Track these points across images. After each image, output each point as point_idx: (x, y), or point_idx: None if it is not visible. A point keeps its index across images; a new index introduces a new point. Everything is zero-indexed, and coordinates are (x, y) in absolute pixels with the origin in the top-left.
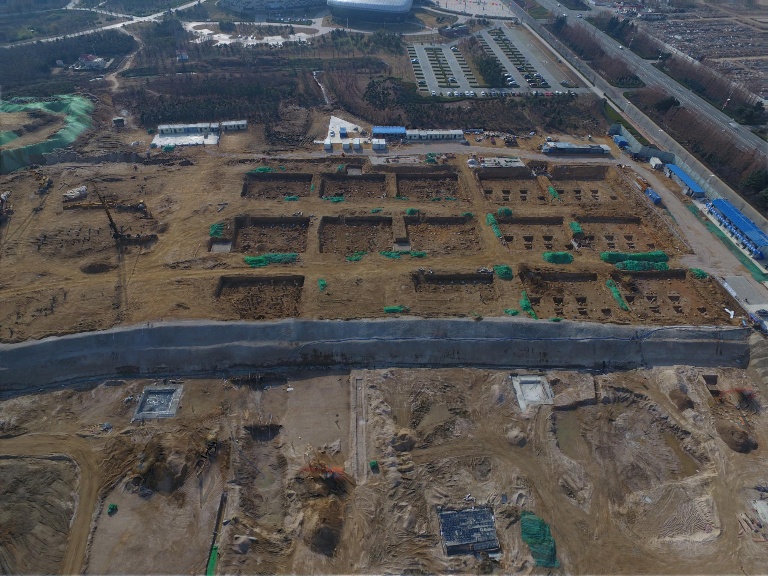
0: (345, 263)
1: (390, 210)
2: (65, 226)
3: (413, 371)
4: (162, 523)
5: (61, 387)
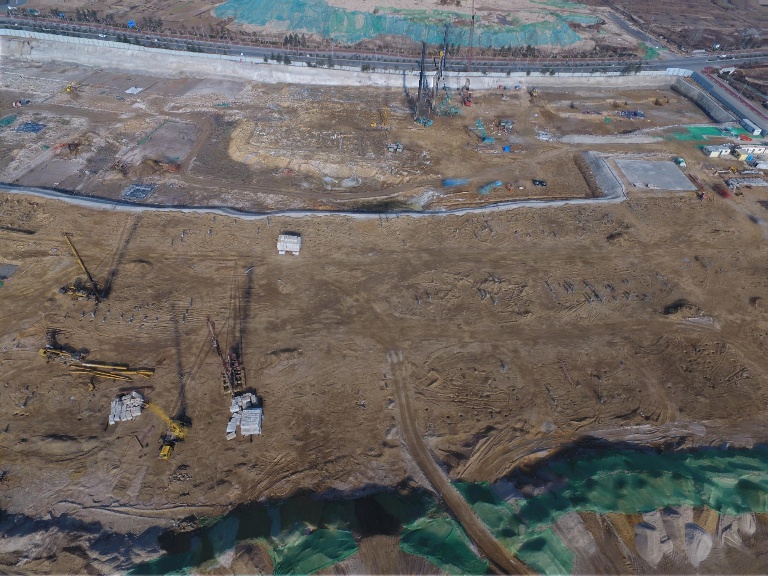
0: None
1: None
2: (158, 335)
3: None
4: (156, 152)
5: (194, 207)
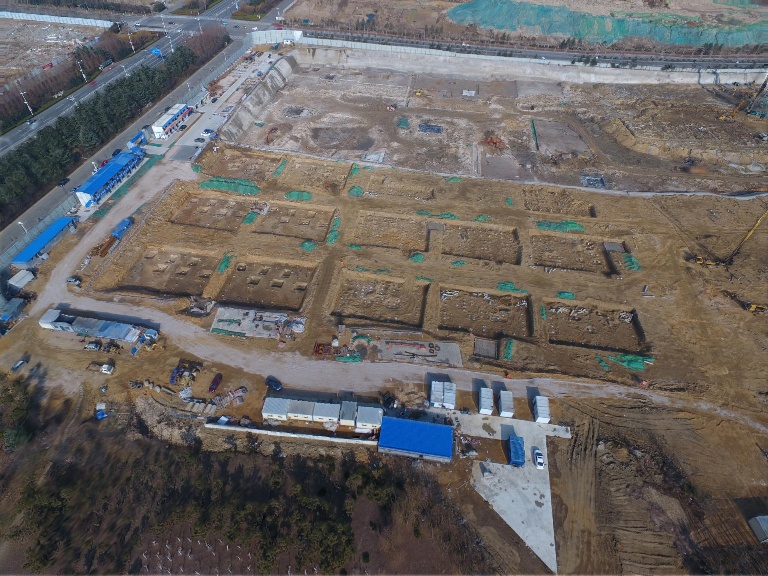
0: (491, 215)
1: (442, 262)
2: None
3: (442, 171)
4: (562, 147)
5: None
